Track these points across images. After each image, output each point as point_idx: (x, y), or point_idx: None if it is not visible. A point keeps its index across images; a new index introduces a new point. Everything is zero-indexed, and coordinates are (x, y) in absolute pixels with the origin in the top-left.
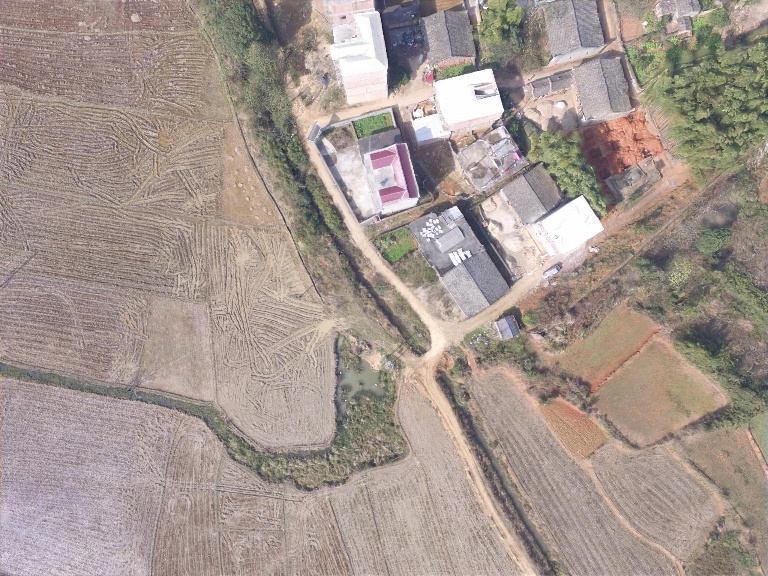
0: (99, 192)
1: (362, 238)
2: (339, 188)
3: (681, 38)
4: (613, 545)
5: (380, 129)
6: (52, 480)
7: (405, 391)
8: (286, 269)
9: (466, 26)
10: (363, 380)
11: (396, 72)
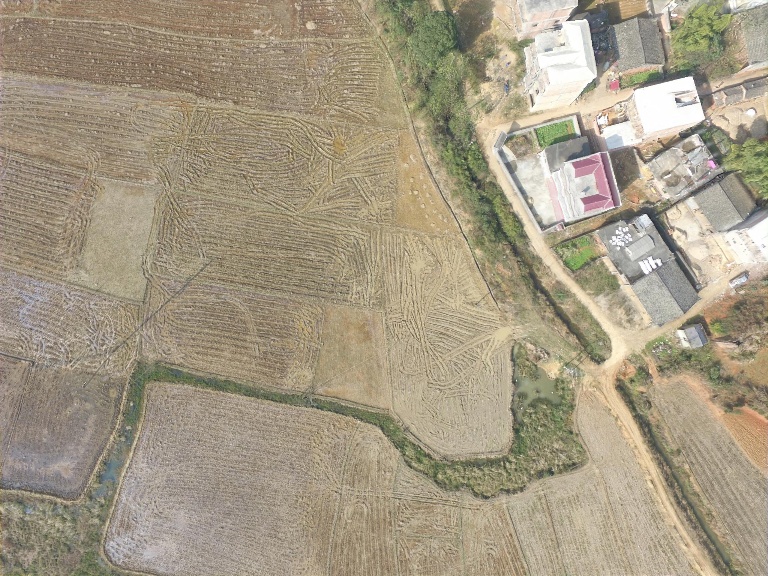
0: (274, 199)
1: (542, 246)
2: (521, 196)
3: None
4: None
5: (562, 136)
6: (228, 487)
7: (584, 399)
8: (462, 276)
9: (655, 33)
10: (539, 388)
11: None
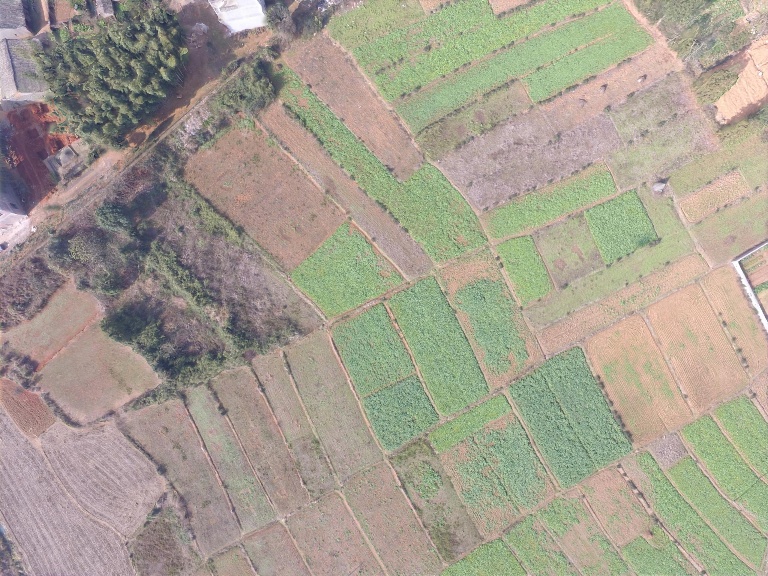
0: None
1: None
2: None
3: None
4: (63, 523)
5: None
6: None
7: None
8: None
9: None
10: None
11: None
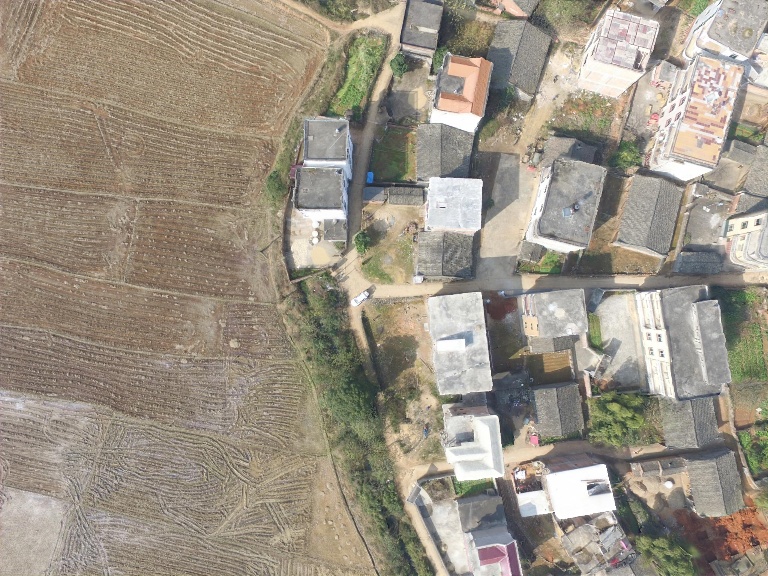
0: (185, 520)
1: None
2: (434, 545)
3: None
4: None
5: (479, 484)
6: None
7: None
8: None
9: (576, 398)
10: None
11: (502, 441)
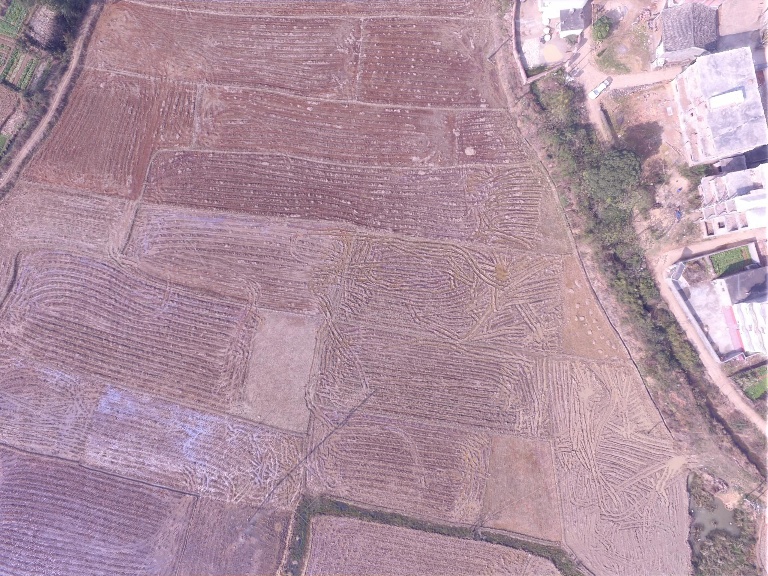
0: (437, 328)
1: (719, 374)
2: (698, 325)
3: None
4: None
5: (737, 263)
6: None
7: (766, 532)
8: (632, 404)
9: None
10: (716, 518)
11: None
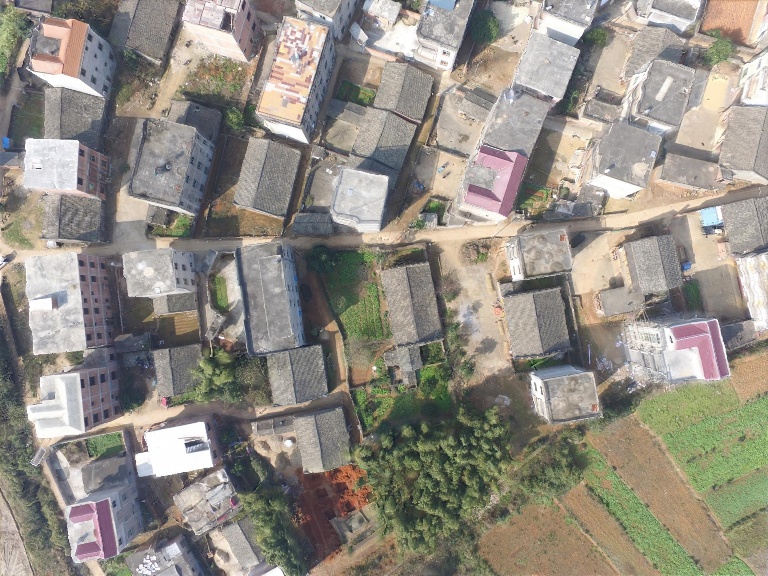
0: None
1: None
2: None
3: (408, 386)
4: None
5: (114, 447)
6: None
7: None
8: None
9: (197, 359)
10: None
11: (123, 402)
